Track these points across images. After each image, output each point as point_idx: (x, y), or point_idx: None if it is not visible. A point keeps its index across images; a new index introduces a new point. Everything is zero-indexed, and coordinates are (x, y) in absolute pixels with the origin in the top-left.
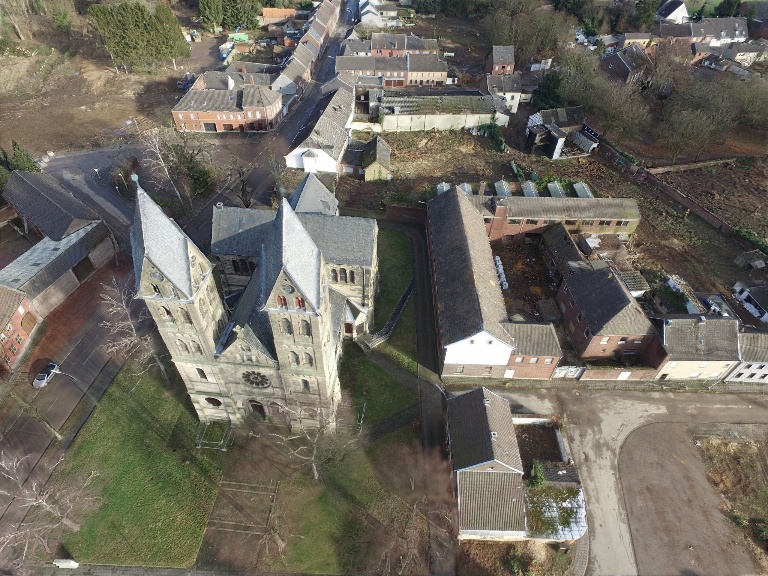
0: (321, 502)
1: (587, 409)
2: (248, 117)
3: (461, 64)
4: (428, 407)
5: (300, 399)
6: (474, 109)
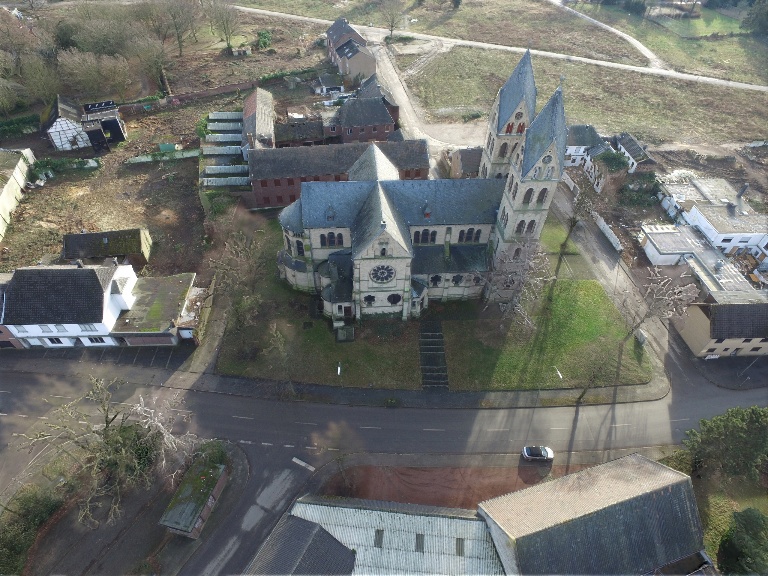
0: None
1: None
2: None
3: None
4: None
5: None
6: (4, 165)
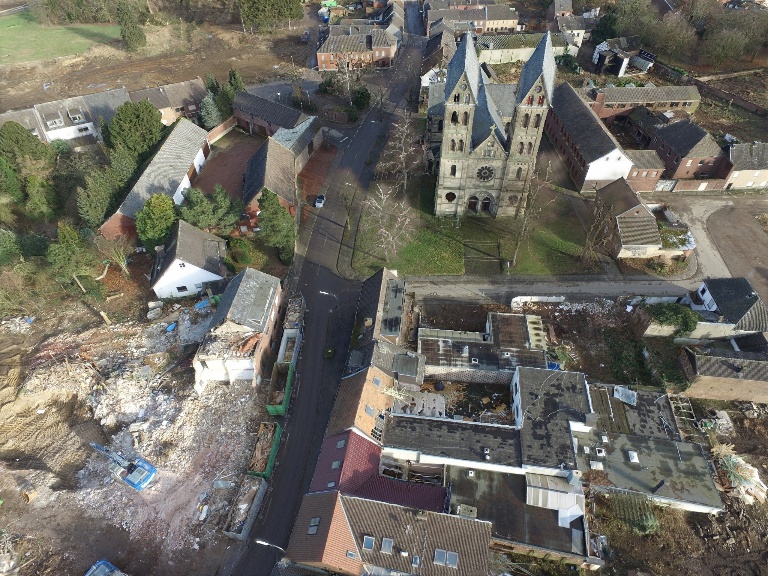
0: None
1: (681, 204)
2: (375, 56)
3: (522, 16)
4: (577, 207)
5: (510, 187)
6: None
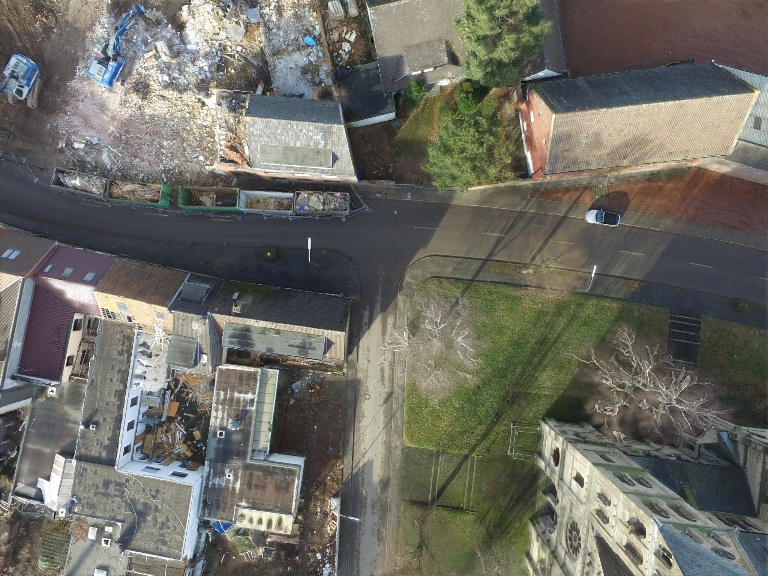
0: (456, 556)
1: None
2: None
3: None
4: None
5: (554, 574)
6: None
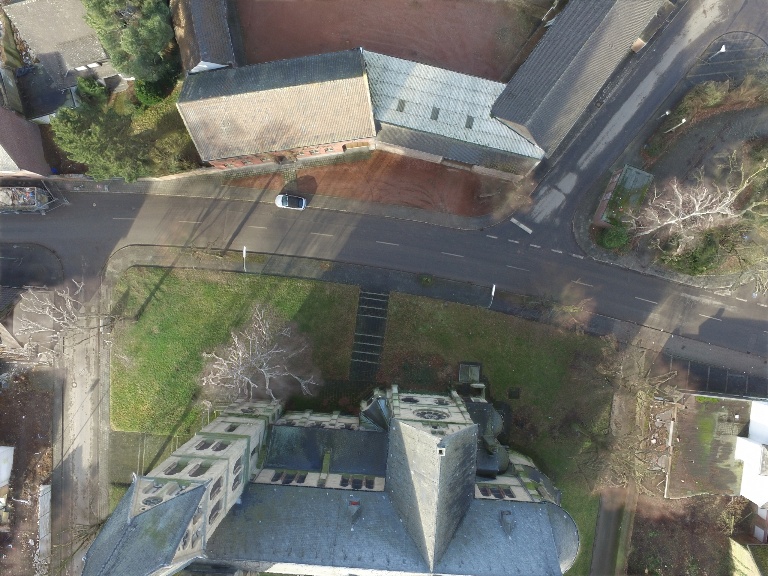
0: None
1: None
2: None
3: None
4: None
5: None
6: None
